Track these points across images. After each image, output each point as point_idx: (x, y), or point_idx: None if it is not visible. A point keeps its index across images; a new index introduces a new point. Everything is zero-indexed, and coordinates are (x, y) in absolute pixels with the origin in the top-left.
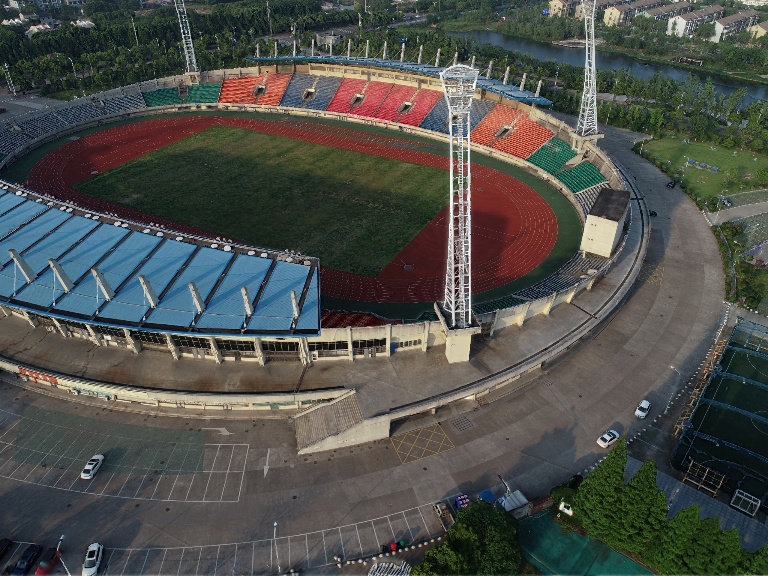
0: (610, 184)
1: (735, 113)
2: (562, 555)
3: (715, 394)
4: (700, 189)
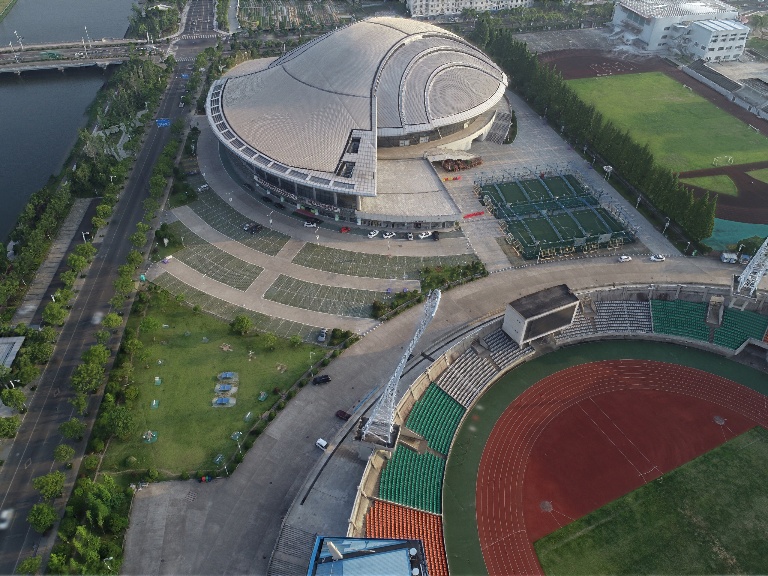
0: (435, 378)
1: (3, 421)
2: (713, 245)
3: (575, 249)
4: (304, 361)
